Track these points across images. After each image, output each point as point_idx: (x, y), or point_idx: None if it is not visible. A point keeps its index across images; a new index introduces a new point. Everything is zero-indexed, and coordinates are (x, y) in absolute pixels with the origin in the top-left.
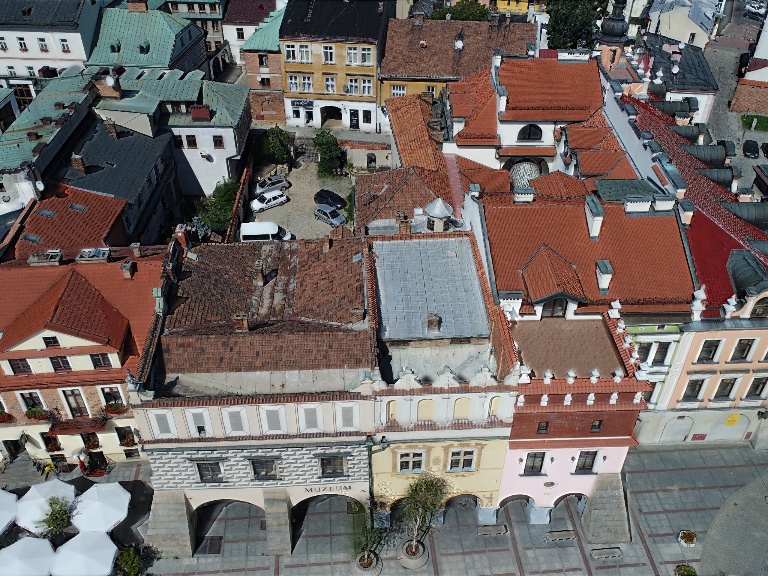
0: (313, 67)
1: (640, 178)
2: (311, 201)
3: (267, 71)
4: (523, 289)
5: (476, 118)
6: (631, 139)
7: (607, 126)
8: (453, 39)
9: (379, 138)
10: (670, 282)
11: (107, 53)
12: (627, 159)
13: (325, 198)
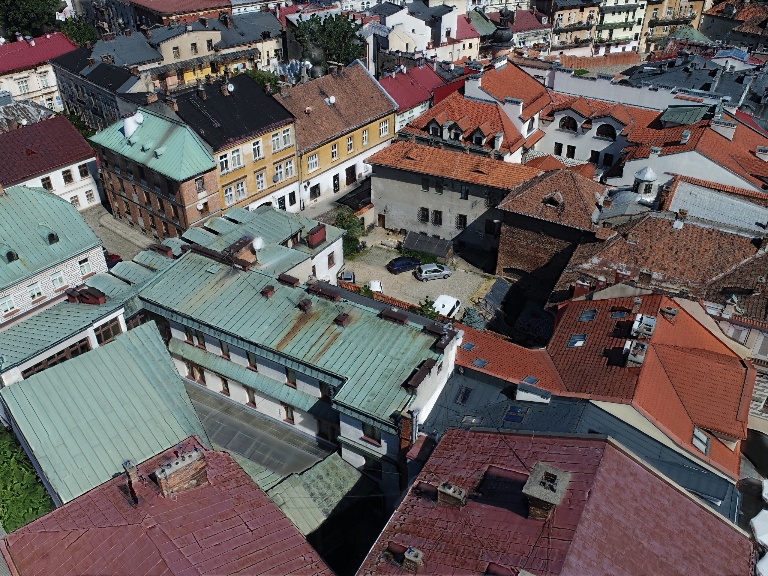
0: (245, 170)
1: (658, 111)
2: (391, 276)
3: (204, 195)
4: (760, 181)
5: (505, 129)
6: (625, 93)
7: (575, 97)
8: (321, 98)
9: (312, 213)
10: (767, 145)
11: (2, 267)
12: (629, 106)
13: (406, 264)
